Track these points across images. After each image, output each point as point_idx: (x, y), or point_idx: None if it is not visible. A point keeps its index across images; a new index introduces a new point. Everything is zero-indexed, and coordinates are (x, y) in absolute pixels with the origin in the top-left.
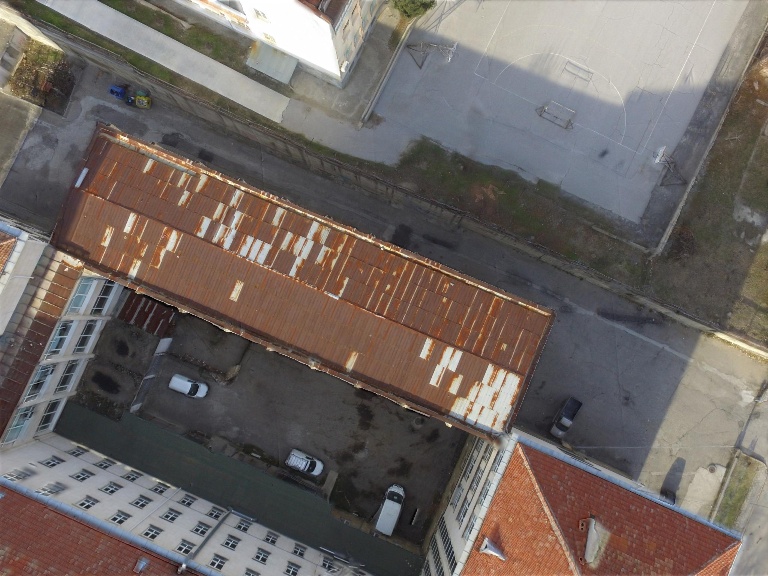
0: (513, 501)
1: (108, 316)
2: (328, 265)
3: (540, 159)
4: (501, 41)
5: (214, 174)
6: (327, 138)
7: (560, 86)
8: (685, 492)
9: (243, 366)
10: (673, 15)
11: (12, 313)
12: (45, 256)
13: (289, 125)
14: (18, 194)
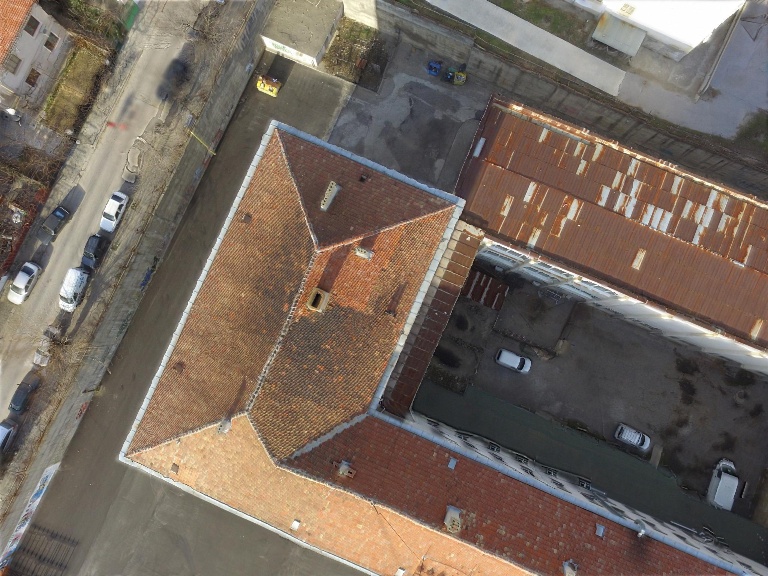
0: None
1: None
2: (730, 233)
3: None
4: None
5: (611, 143)
6: (665, 111)
7: None
8: None
9: None
10: None
11: None
12: None
13: (626, 98)
14: None
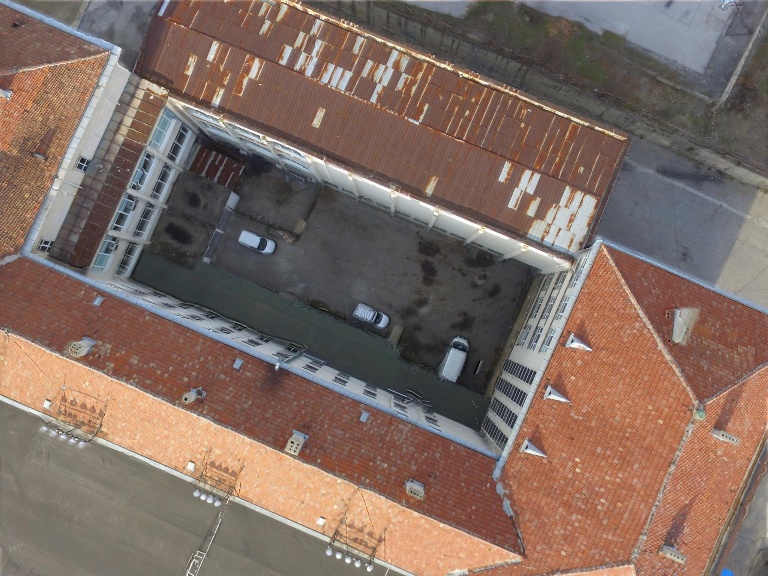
0: (598, 298)
1: (180, 167)
2: (408, 92)
3: (606, 10)
4: None
5: (294, 3)
6: None
7: None
8: None
9: (309, 224)
10: None
11: (100, 139)
12: (130, 84)
13: None
14: None
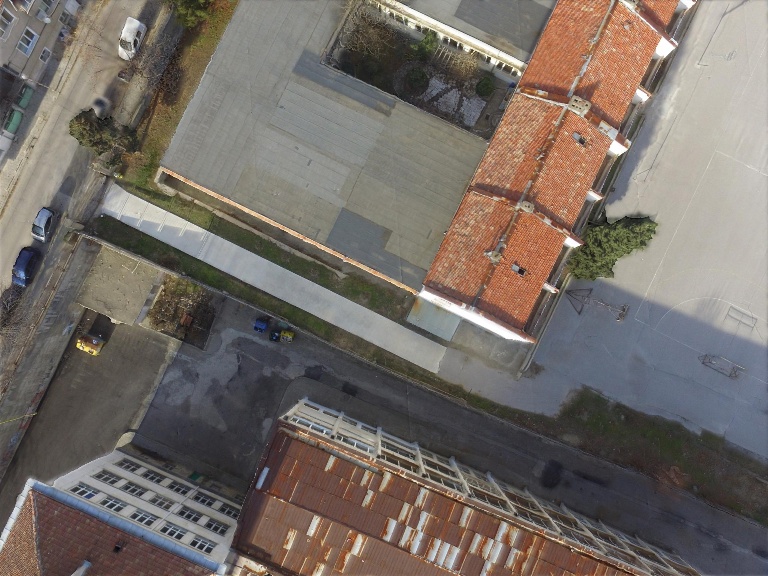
0: None
1: None
2: (518, 569)
3: (703, 408)
4: (661, 285)
5: (398, 473)
6: (485, 389)
7: (723, 332)
8: None
9: None
10: None
11: None
12: (227, 562)
13: (446, 376)
14: (159, 431)
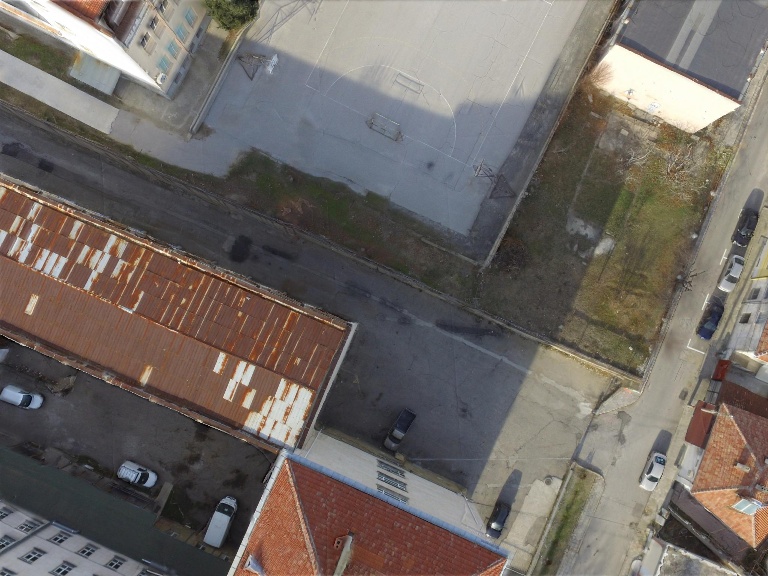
0: (278, 518)
1: None
2: (124, 279)
3: (370, 171)
4: (333, 53)
5: (12, 187)
6: (155, 149)
7: (391, 98)
8: (521, 504)
9: (79, 377)
10: (505, 28)
11: None
12: None
13: (118, 136)
14: None
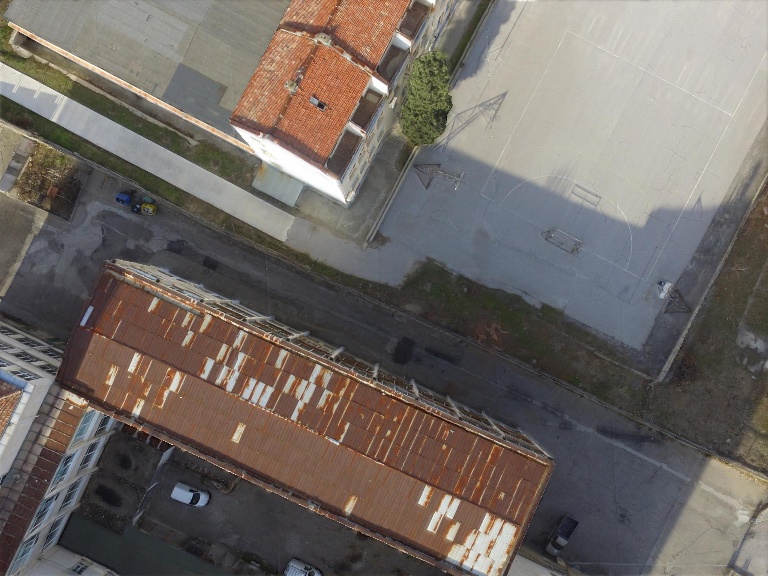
0: None
1: (112, 430)
2: (329, 409)
3: (544, 283)
4: (509, 162)
5: (218, 315)
6: (331, 258)
7: (567, 210)
8: None
9: None
10: (684, 139)
11: (18, 451)
12: (50, 394)
13: (294, 244)
14: (24, 298)
